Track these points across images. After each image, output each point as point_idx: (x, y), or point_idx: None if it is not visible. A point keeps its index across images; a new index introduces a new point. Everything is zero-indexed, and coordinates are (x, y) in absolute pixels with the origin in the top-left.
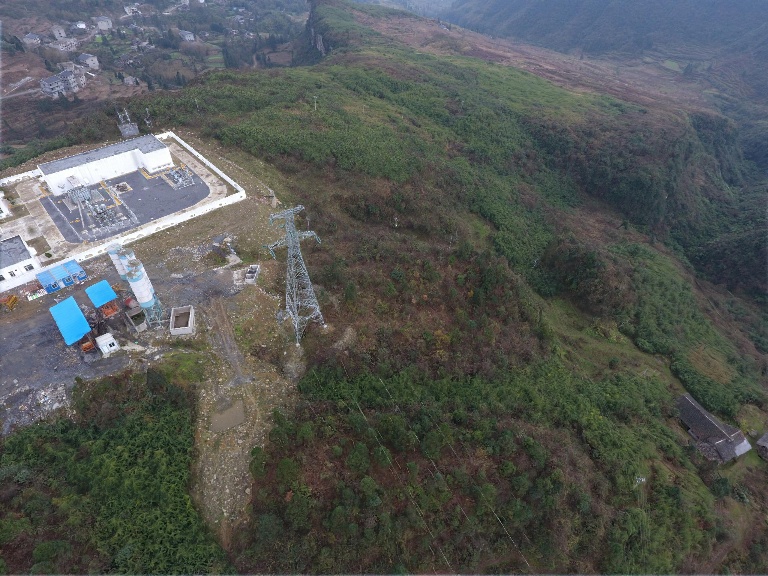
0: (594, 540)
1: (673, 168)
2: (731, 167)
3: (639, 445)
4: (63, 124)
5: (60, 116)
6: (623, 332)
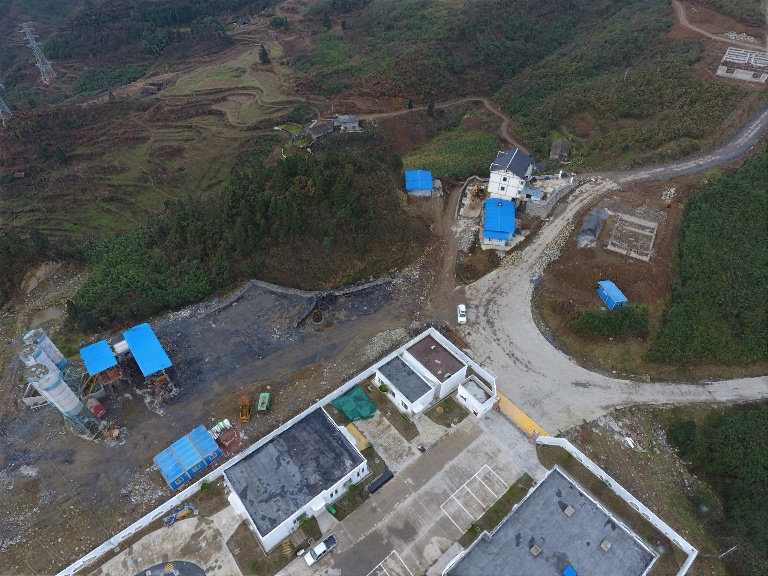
0: None
1: None
2: None
3: None
4: None
5: None
6: None
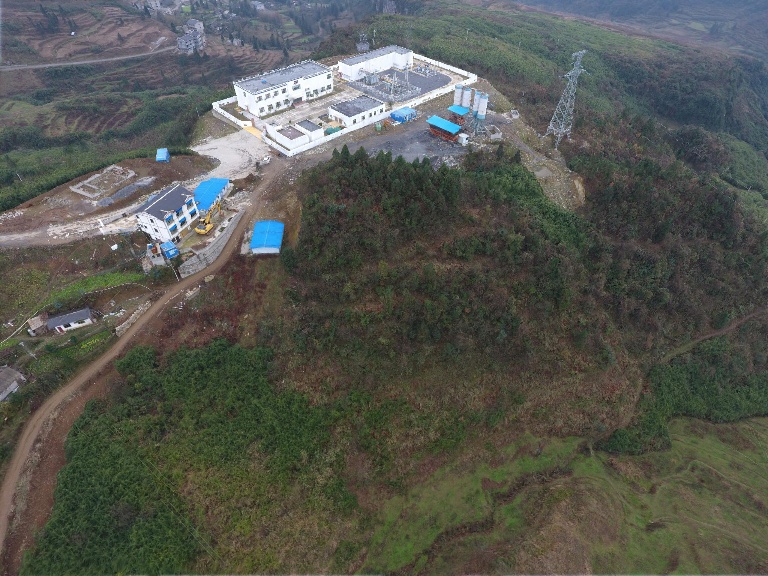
0: (751, 234)
1: (731, 90)
2: (765, 105)
3: (761, 208)
4: (198, 76)
5: (195, 69)
6: (723, 179)
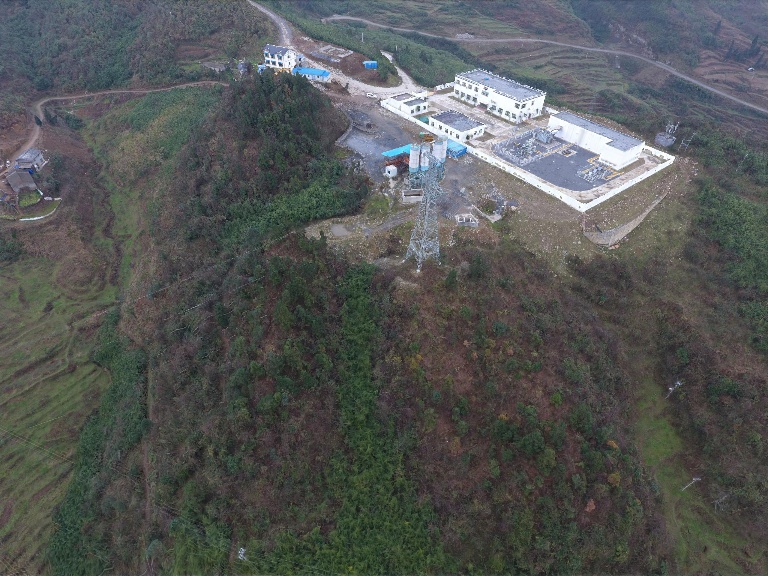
0: None
1: None
2: None
3: None
4: None
5: None
6: None
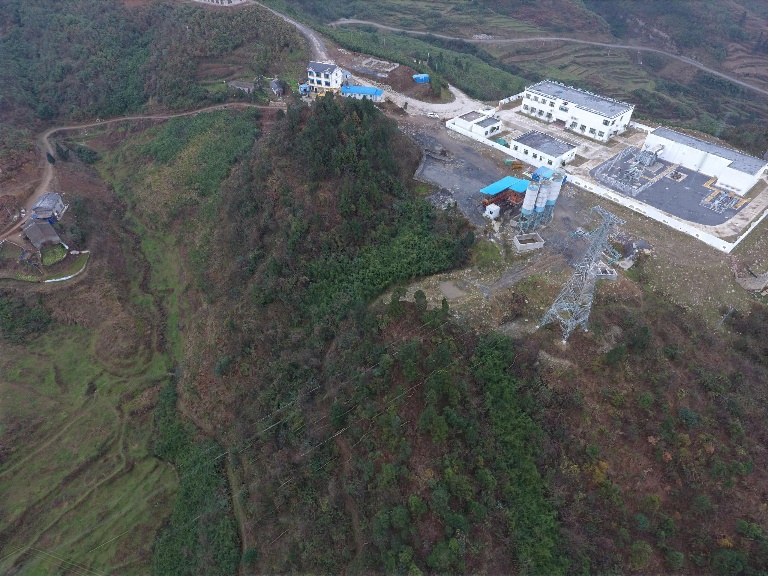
0: None
1: None
2: None
3: None
4: None
5: None
6: None
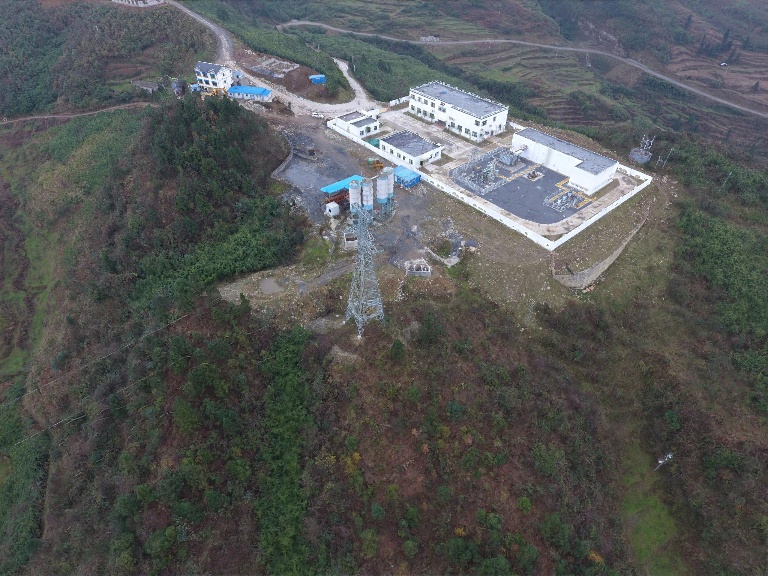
0: None
1: None
2: None
3: None
4: None
5: None
6: None
